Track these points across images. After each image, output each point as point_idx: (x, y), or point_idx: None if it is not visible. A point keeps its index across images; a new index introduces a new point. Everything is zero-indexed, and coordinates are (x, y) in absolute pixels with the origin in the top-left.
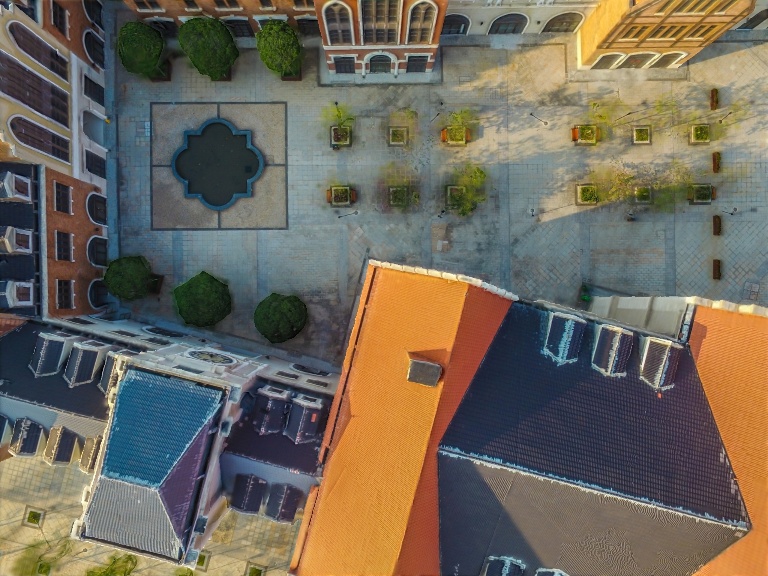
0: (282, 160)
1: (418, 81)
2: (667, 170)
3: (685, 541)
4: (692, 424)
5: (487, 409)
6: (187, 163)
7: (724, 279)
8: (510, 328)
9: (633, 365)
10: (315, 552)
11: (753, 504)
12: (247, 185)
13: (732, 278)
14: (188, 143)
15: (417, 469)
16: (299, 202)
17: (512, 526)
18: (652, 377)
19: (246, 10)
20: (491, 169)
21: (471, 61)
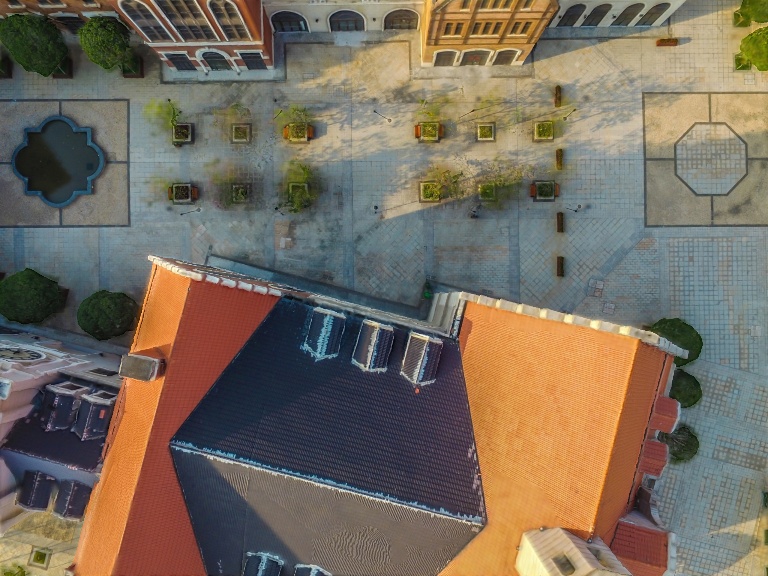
0: (124, 157)
1: (261, 78)
2: (511, 167)
3: (425, 536)
4: (446, 419)
5: (230, 404)
6: (28, 160)
7: (568, 276)
8: (273, 323)
9: (395, 360)
10: (86, 548)
11: (490, 499)
12: (87, 182)
13: (576, 275)
14: (28, 140)
15: (139, 464)
16: (141, 199)
17: (260, 522)
18: (411, 372)
19: (71, 7)
20: (334, 166)
21: (315, 58)
